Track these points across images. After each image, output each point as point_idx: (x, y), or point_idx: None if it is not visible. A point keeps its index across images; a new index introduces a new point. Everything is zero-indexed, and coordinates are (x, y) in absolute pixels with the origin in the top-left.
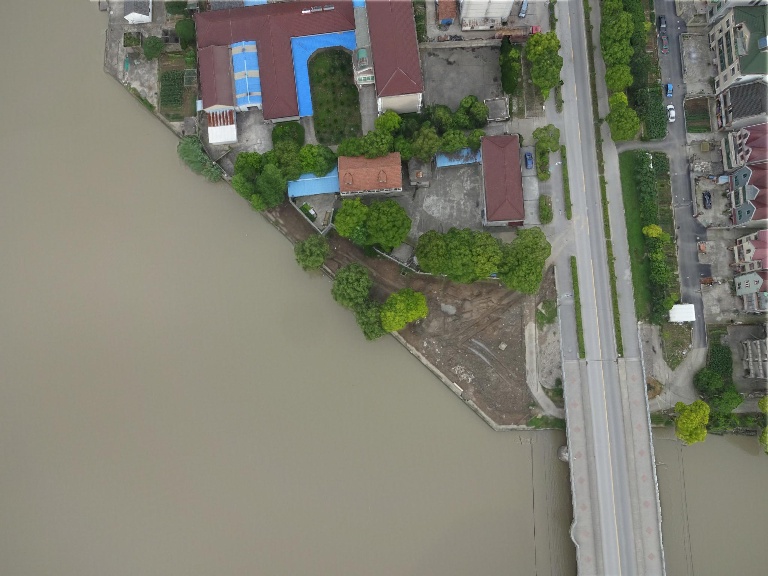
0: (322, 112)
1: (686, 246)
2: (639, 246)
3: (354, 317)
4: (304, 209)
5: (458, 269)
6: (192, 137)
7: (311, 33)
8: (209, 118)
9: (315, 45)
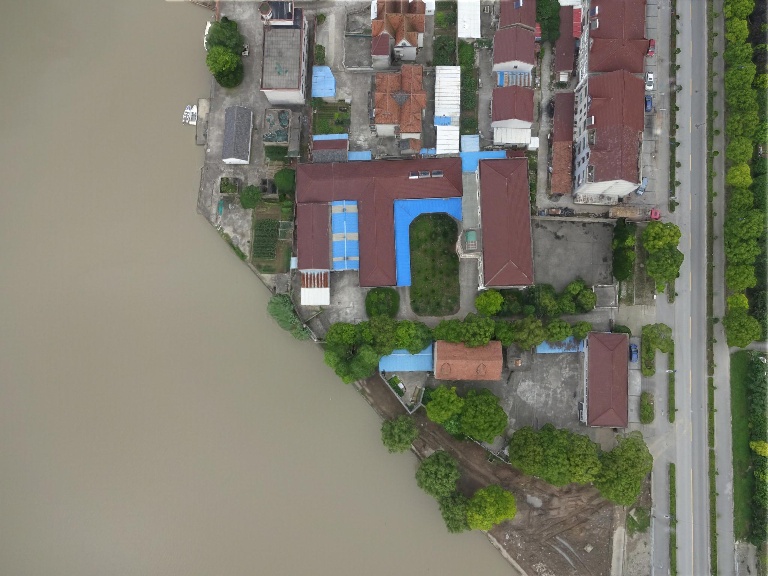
0: (419, 279)
1: None
2: (744, 458)
3: (437, 504)
4: (393, 382)
5: (553, 476)
6: (284, 296)
7: (416, 197)
8: (303, 279)
9: (418, 209)
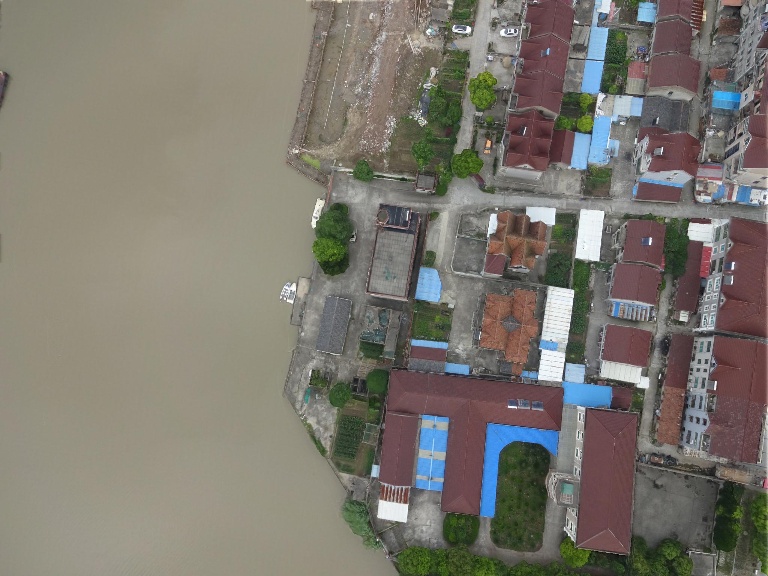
0: (503, 508)
1: None
2: None
3: None
4: None
5: None
6: (360, 504)
7: (511, 423)
8: (383, 490)
9: (512, 436)
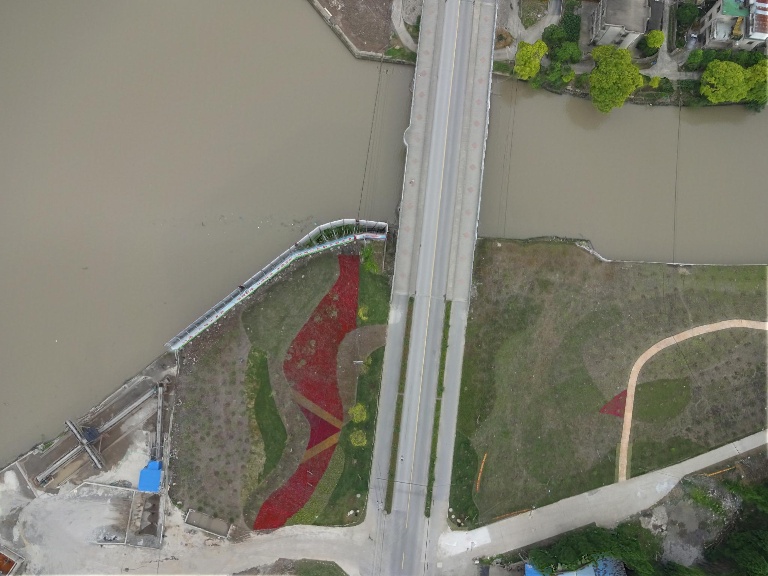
0: None
1: None
2: None
3: None
4: None
5: None
6: None
7: None
8: None
9: None
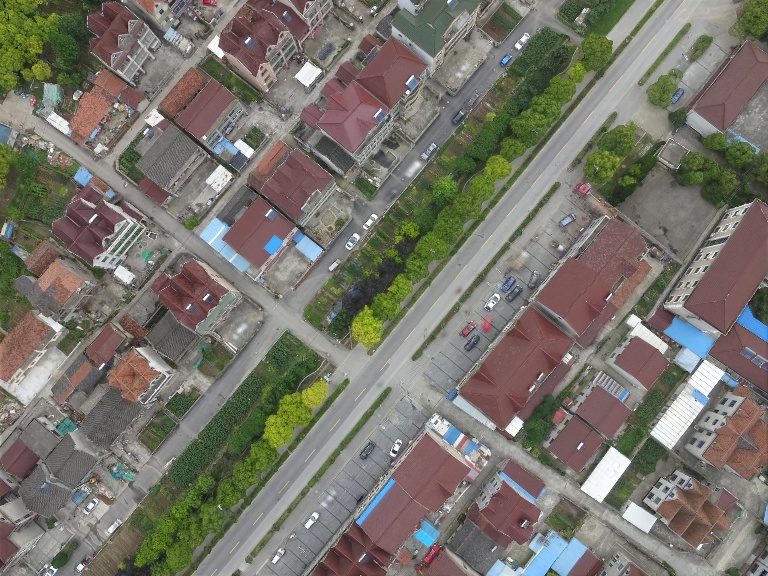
0: None
1: None
2: None
3: None
4: None
5: None
6: None
7: None
8: None
9: None
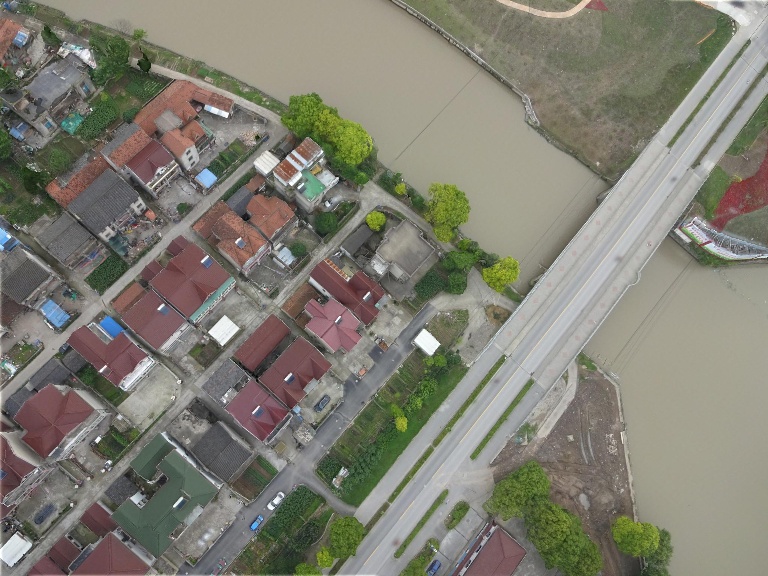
0: None
1: (371, 384)
2: (414, 420)
3: None
4: None
5: None
6: None
7: None
8: None
9: None
